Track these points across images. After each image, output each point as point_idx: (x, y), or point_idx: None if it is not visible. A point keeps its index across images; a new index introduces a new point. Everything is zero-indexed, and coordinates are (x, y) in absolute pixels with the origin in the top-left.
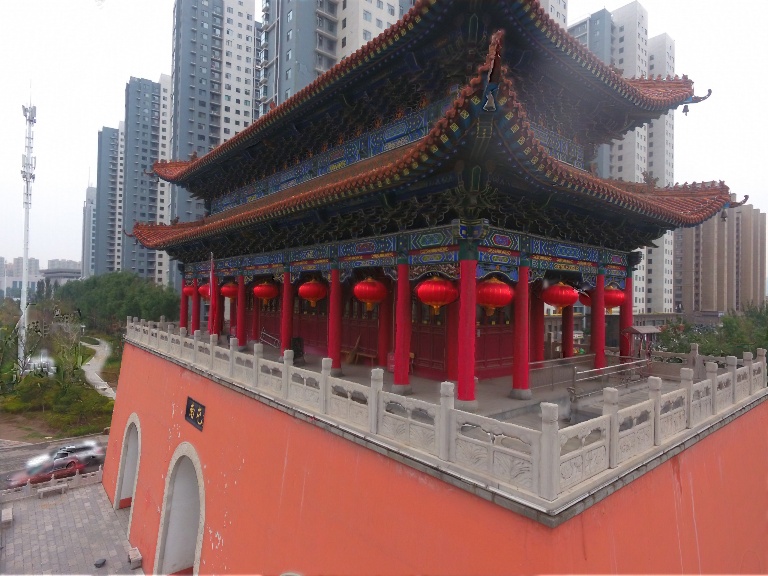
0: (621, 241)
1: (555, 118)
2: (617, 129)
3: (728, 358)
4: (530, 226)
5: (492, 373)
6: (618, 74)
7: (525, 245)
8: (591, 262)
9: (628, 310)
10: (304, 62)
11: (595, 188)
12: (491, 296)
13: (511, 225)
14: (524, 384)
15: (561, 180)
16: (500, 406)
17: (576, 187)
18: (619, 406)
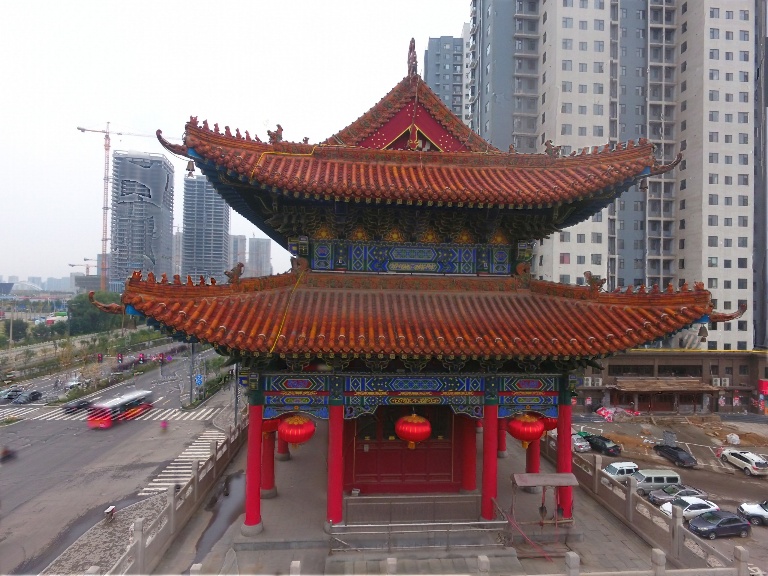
0: (531, 364)
1: (442, 230)
2: (550, 221)
3: (566, 555)
4: (349, 364)
5: (389, 488)
6: (553, 153)
7: (334, 385)
8: (471, 391)
9: (562, 445)
10: (502, 91)
11: (326, 352)
12: (280, 435)
13: (317, 367)
14: (330, 518)
15: (266, 354)
16: (289, 535)
17: (295, 355)
18: (374, 573)
